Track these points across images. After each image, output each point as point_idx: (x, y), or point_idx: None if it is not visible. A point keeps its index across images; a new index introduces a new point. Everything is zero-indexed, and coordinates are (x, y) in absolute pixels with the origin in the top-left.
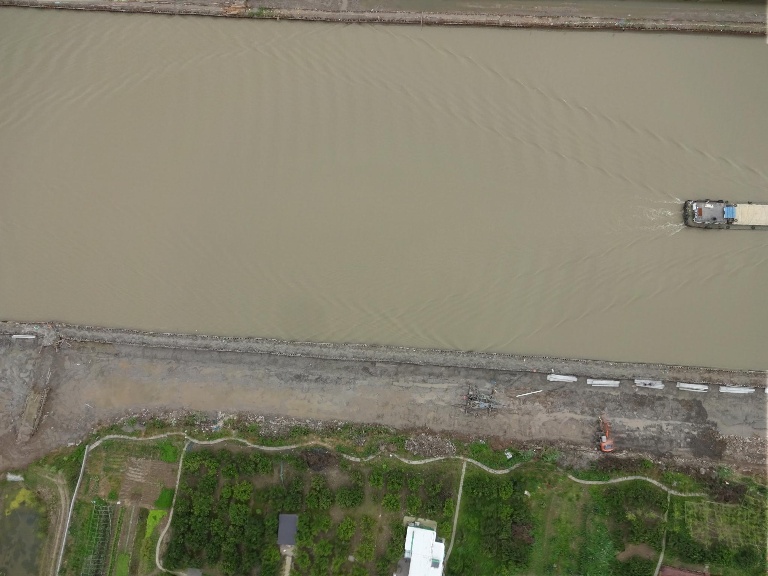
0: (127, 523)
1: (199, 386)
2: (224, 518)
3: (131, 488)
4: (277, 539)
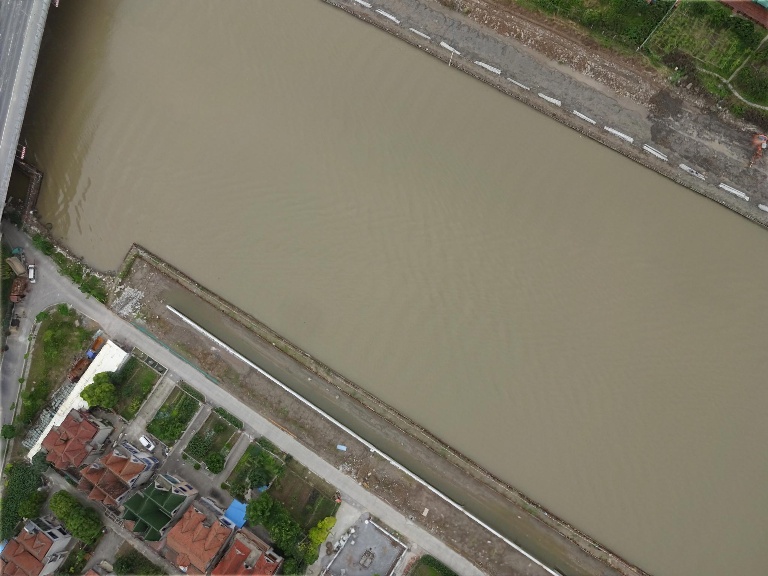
0: None
1: None
2: None
3: None
4: None
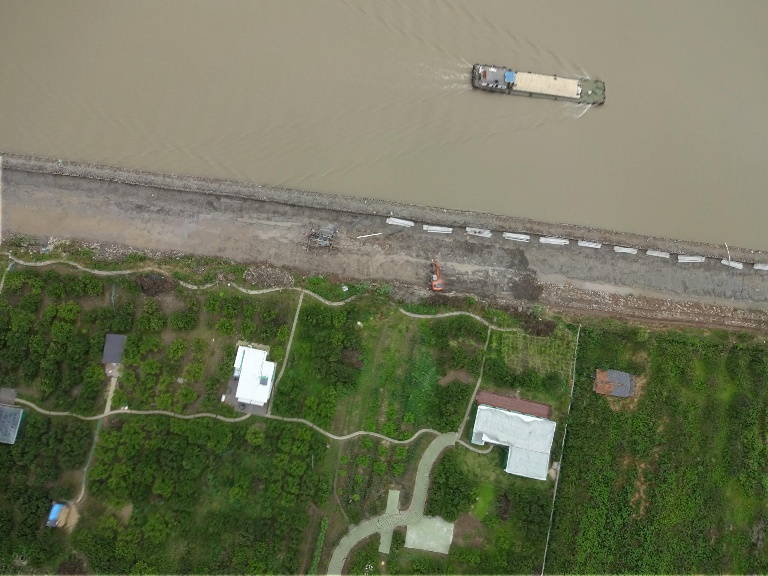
0: None
1: (30, 210)
2: (45, 335)
3: None
4: (102, 357)
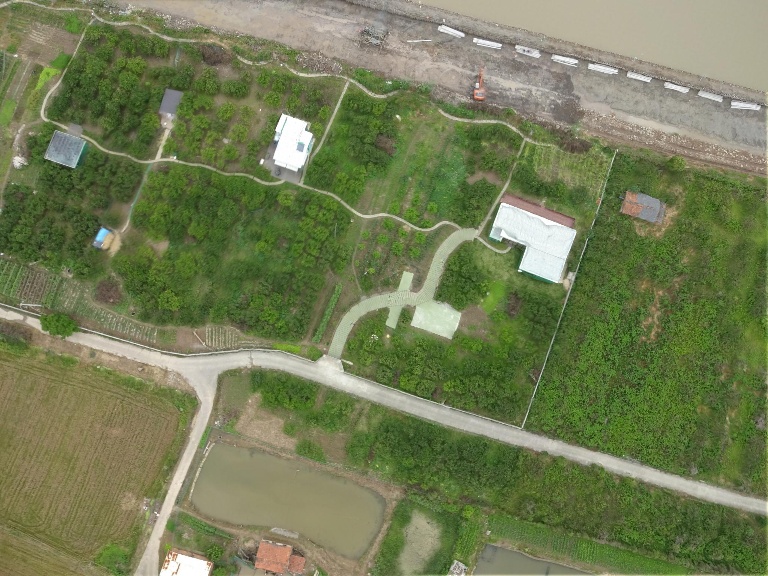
0: (20, 73)
1: None
2: (113, 80)
3: (31, 47)
4: (160, 106)
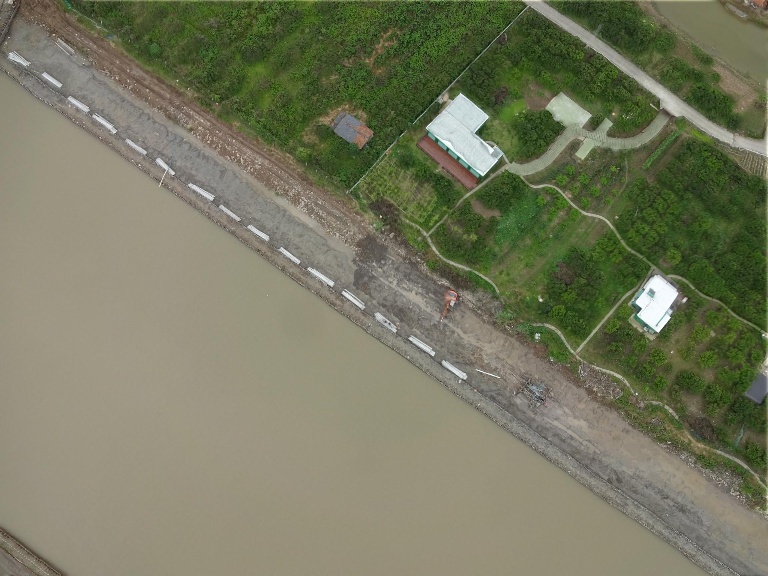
0: None
1: None
2: None
3: None
4: None
